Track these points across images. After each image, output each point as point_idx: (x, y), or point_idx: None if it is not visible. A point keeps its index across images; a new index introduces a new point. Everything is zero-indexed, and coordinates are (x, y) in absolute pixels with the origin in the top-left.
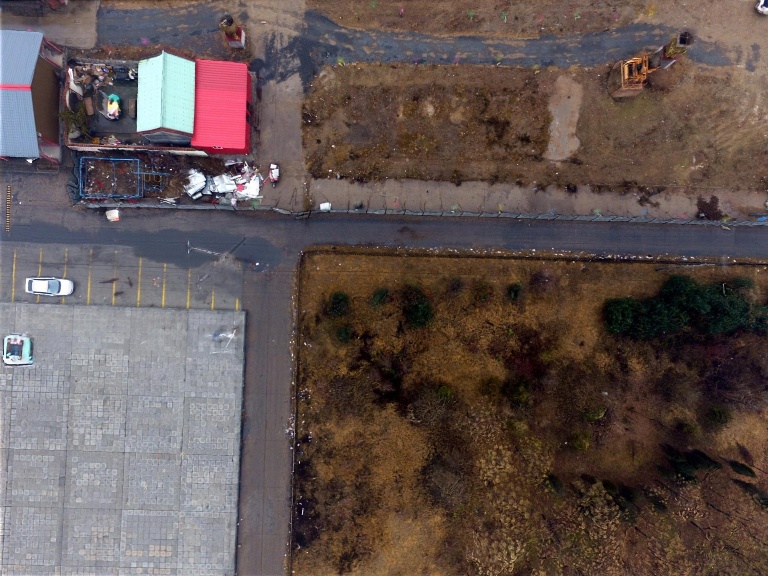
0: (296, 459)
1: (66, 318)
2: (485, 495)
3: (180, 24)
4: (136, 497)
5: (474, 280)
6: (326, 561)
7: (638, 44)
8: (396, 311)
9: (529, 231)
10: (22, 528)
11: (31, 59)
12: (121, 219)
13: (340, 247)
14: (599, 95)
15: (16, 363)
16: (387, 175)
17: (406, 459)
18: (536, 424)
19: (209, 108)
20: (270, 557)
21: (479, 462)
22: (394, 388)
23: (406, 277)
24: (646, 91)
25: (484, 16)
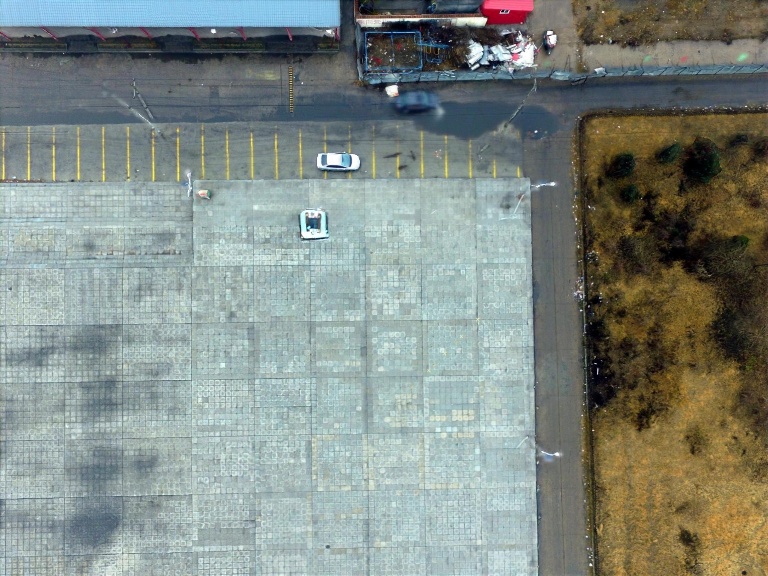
0: (588, 320)
1: (358, 191)
2: None
3: None
4: (436, 364)
5: (752, 135)
6: (624, 418)
7: None
8: (677, 170)
9: None
10: (328, 398)
11: None
12: (401, 94)
13: (617, 110)
14: None
15: (314, 237)
16: (658, 37)
17: (697, 314)
18: None
19: None
20: (567, 418)
21: None
22: None
23: (685, 136)
24: None
25: None
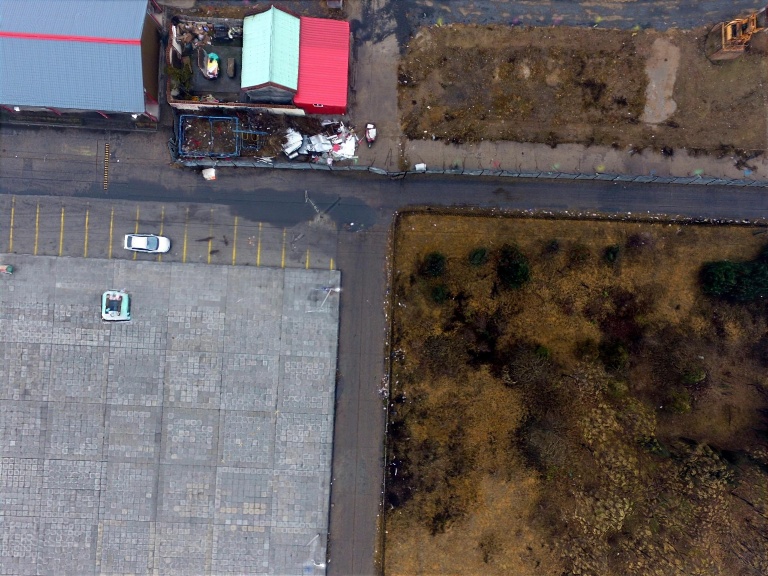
0: (390, 419)
1: (163, 275)
2: (579, 458)
3: None
4: (231, 454)
5: (569, 242)
6: (419, 522)
7: (736, 7)
8: (491, 272)
9: (625, 194)
10: (118, 483)
11: (139, 14)
12: (217, 178)
13: (435, 208)
14: (696, 58)
15: (114, 319)
16: (482, 136)
17: (500, 421)
18: (632, 387)
19: (312, 65)
20: (363, 517)
21: (583, 421)
22: (490, 349)
23: (501, 238)
24: (744, 54)
25: None
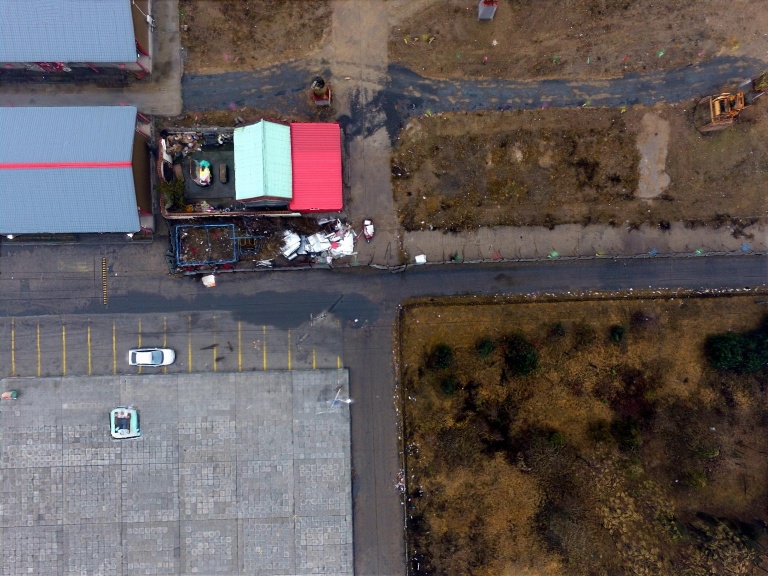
0: (408, 514)
1: (170, 388)
2: (599, 538)
3: (264, 85)
4: (252, 563)
5: (574, 323)
6: None
7: (722, 77)
8: (498, 359)
9: (625, 270)
10: None
11: (128, 134)
12: (218, 284)
13: (438, 298)
14: (686, 130)
15: (124, 436)
16: (480, 223)
17: (518, 507)
18: (646, 464)
19: (305, 171)
20: None
21: (602, 511)
22: (503, 437)
23: (506, 325)
24: (733, 123)
25: (566, 58)
